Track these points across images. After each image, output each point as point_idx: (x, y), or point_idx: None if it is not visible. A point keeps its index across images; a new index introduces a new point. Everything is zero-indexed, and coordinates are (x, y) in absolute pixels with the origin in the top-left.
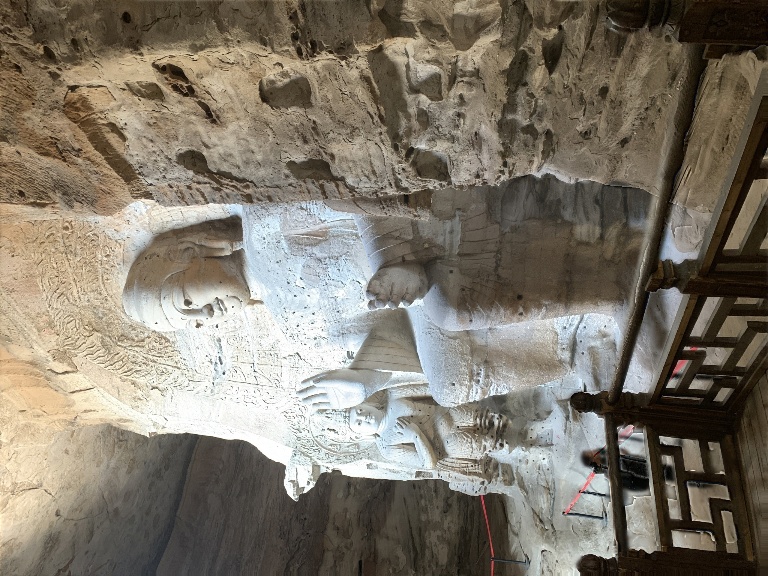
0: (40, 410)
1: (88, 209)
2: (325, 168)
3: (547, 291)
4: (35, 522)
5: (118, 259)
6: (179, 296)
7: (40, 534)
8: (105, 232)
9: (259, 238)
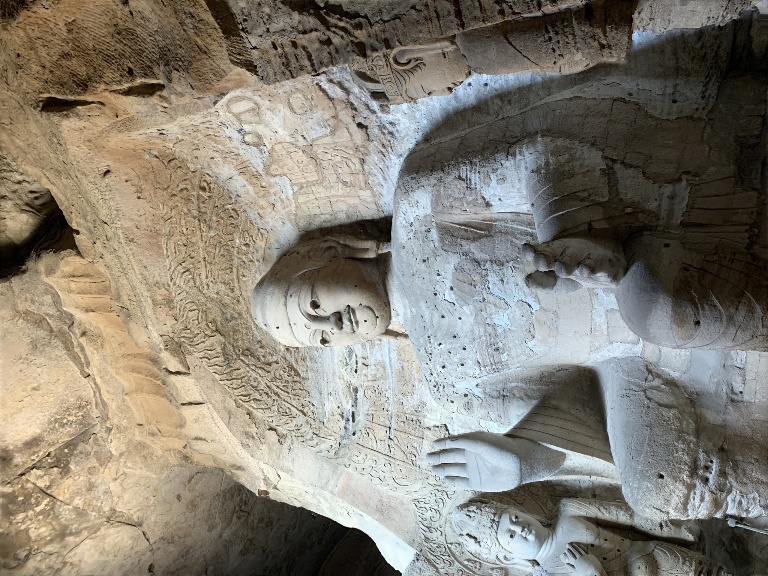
0: (156, 428)
1: (185, 82)
2: None
3: None
4: (122, 567)
5: (258, 254)
6: (306, 295)
7: None
8: (247, 213)
9: (406, 224)
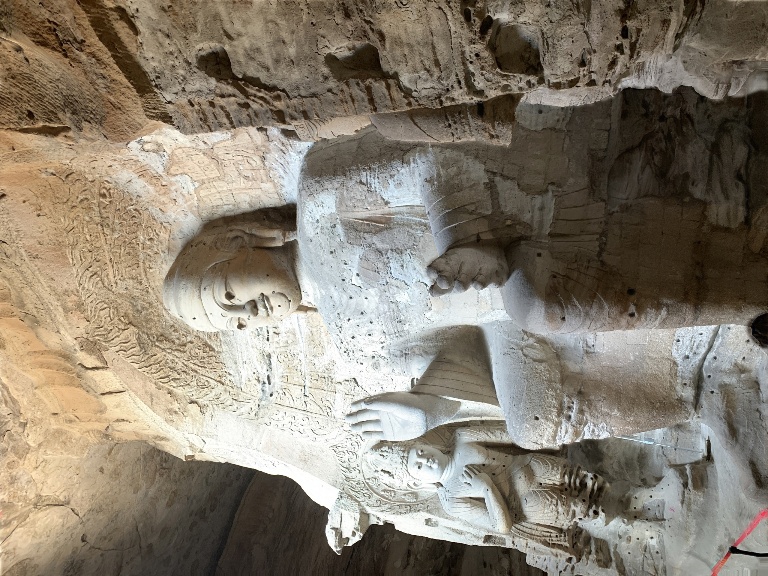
0: (73, 415)
1: (98, 132)
2: (375, 67)
3: (669, 286)
4: (56, 544)
5: (163, 246)
6: (220, 287)
7: (61, 559)
8: (149, 210)
9: (312, 221)
